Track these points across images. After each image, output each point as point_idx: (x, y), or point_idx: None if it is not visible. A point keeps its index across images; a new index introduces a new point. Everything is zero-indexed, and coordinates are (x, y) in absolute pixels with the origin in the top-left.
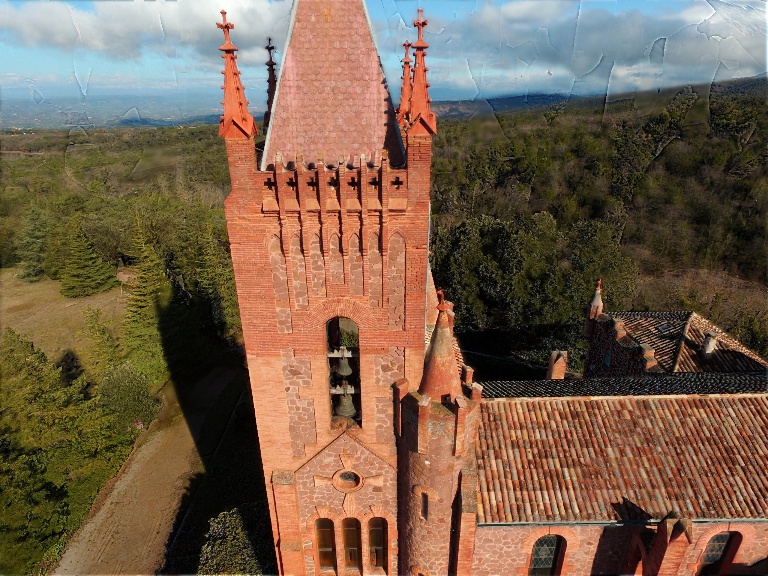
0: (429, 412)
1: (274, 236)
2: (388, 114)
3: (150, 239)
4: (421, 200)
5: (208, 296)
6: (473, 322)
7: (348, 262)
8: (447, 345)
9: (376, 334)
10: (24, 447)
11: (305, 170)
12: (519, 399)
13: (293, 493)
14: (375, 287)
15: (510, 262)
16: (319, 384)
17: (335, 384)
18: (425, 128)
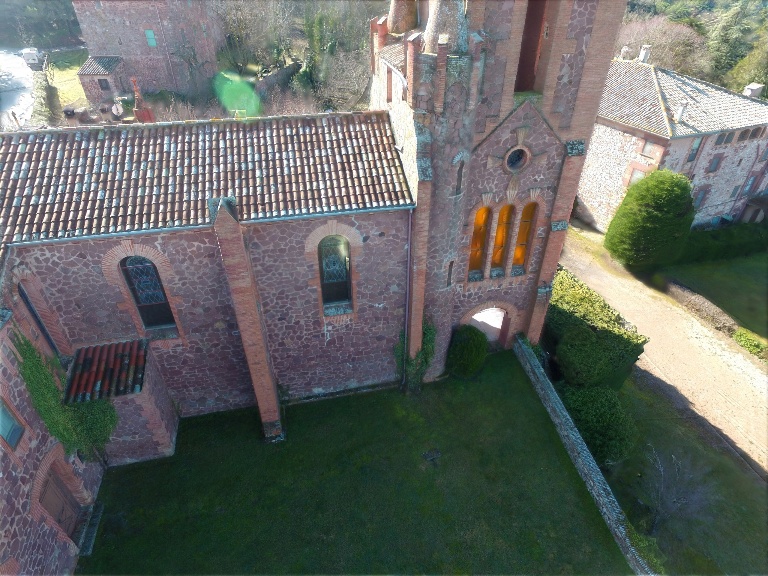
0: None
1: None
2: None
3: None
4: None
5: None
6: None
7: None
8: None
9: None
10: None
11: None
12: None
13: None
14: None
15: None
16: None
17: None
18: None
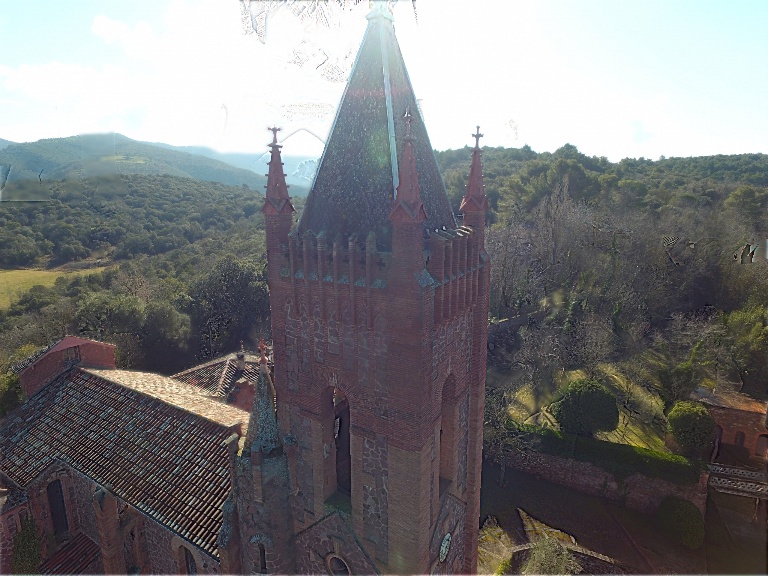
0: None
1: None
2: None
3: None
4: None
5: None
6: None
7: None
8: None
9: None
10: None
11: None
12: None
13: None
14: None
15: None
16: None
17: None
18: None
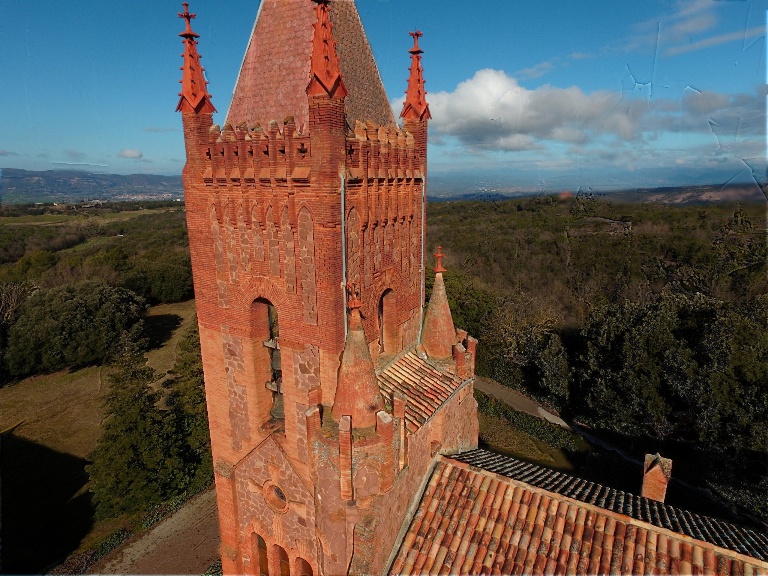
0: (316, 427)
1: (214, 206)
2: None
3: None
4: (323, 169)
5: None
6: (647, 423)
7: (267, 237)
8: (354, 352)
9: (292, 324)
10: (184, 410)
11: (232, 139)
12: (514, 482)
13: (230, 489)
14: (290, 269)
15: (712, 354)
16: (249, 371)
17: (274, 379)
18: (322, 86)
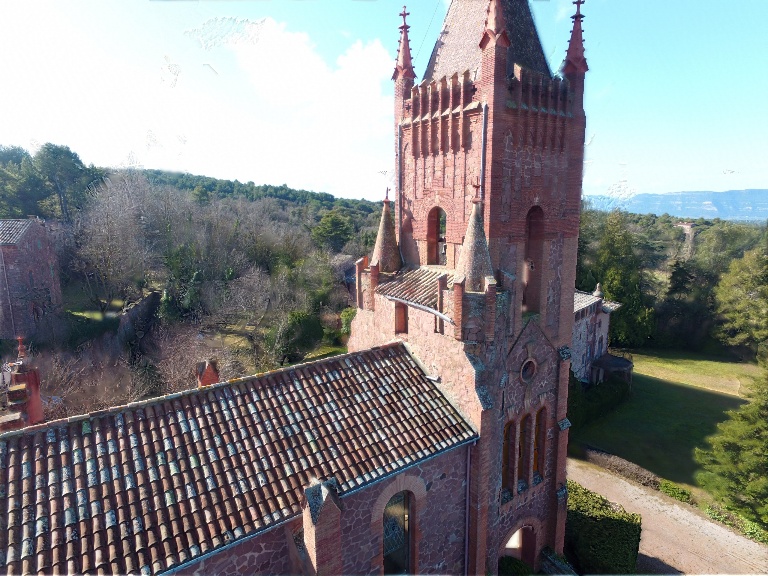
0: None
1: None
2: None
3: None
4: None
5: None
6: None
7: None
8: None
9: None
10: None
11: None
12: None
13: None
14: None
15: None
16: None
17: None
18: None
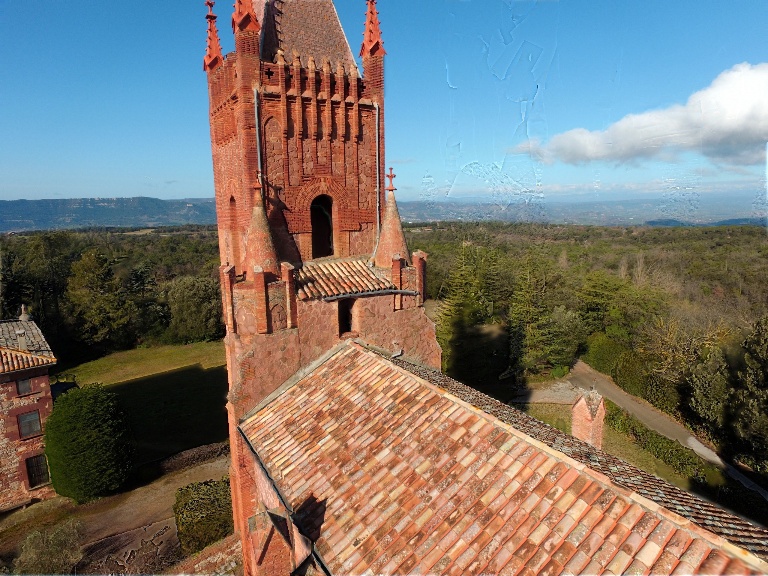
0: None
1: None
2: (261, 29)
3: (470, 262)
4: None
5: (509, 328)
6: None
7: (231, 148)
8: (253, 223)
9: None
10: None
11: None
12: (385, 361)
13: None
14: (238, 169)
15: None
16: None
17: None
18: None
